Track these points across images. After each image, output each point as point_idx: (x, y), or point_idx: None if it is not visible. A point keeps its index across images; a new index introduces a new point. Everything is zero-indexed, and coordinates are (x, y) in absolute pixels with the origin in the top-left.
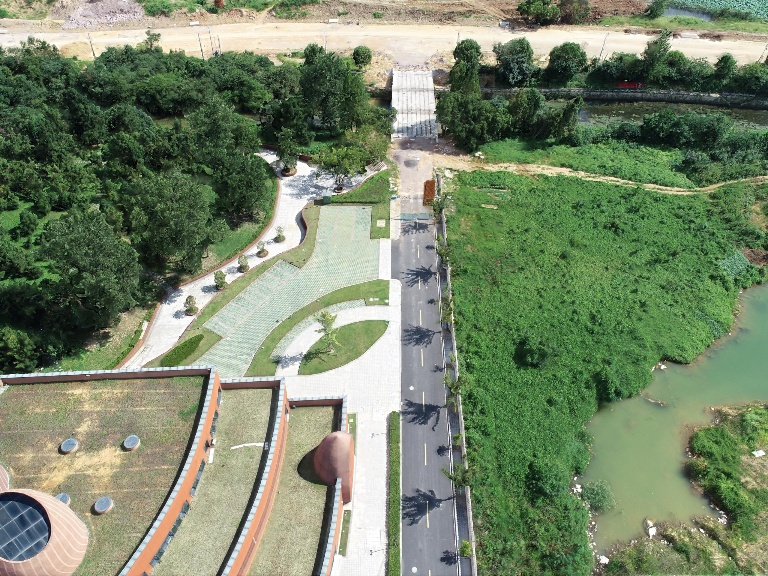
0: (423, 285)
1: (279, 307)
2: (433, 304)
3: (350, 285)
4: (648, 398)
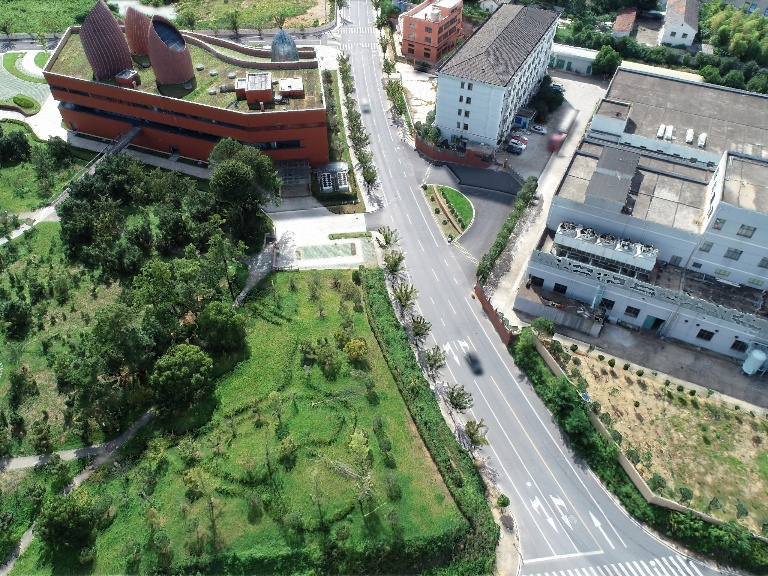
0: (17, 45)
1: (5, 80)
2: (34, 43)
3: (2, 62)
4: (120, 9)
